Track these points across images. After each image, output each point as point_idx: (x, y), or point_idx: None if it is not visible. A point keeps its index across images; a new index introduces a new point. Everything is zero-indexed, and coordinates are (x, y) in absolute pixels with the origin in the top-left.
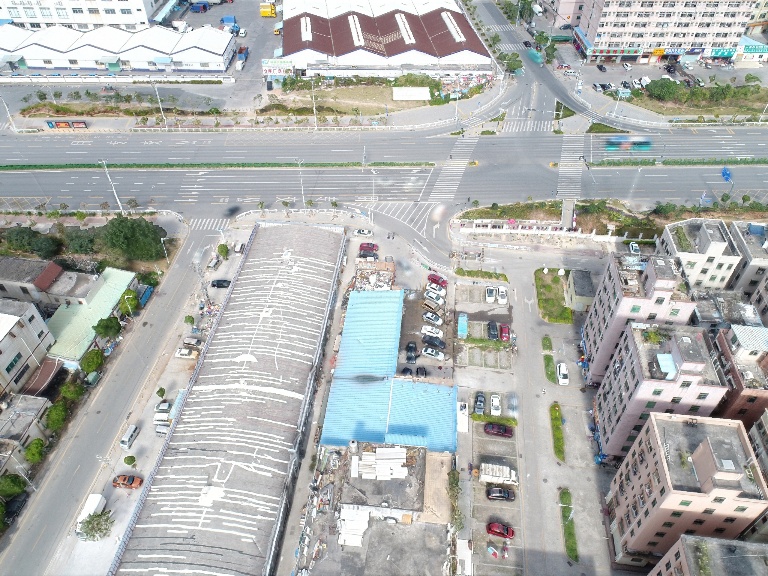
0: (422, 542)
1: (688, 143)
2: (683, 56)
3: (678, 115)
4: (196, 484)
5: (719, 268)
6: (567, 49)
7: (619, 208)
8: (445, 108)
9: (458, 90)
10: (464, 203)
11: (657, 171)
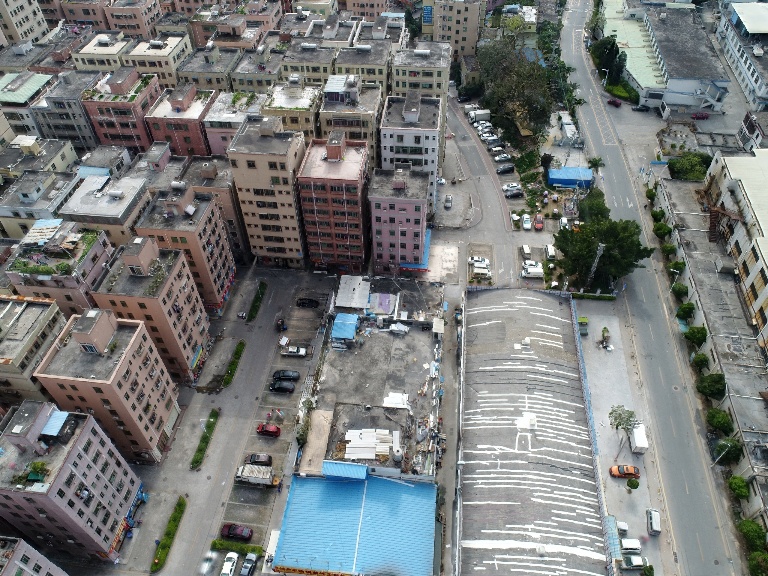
0: (339, 397)
1: None
2: None
3: None
4: (545, 431)
5: None
6: None
7: None
8: None
9: None
10: None
11: None
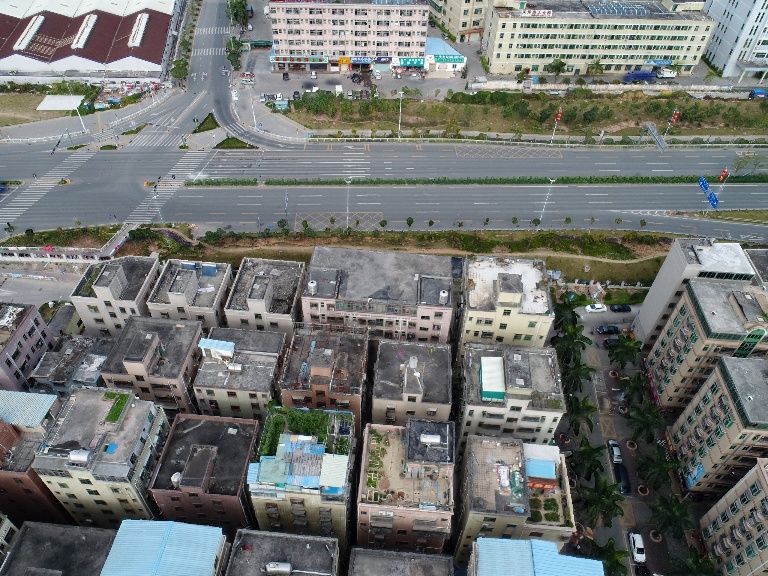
0: None
1: (312, 160)
2: (374, 65)
3: (325, 129)
4: None
5: (124, 312)
6: (267, 55)
7: (181, 233)
8: (85, 119)
9: (109, 99)
10: (19, 227)
11: (255, 191)
